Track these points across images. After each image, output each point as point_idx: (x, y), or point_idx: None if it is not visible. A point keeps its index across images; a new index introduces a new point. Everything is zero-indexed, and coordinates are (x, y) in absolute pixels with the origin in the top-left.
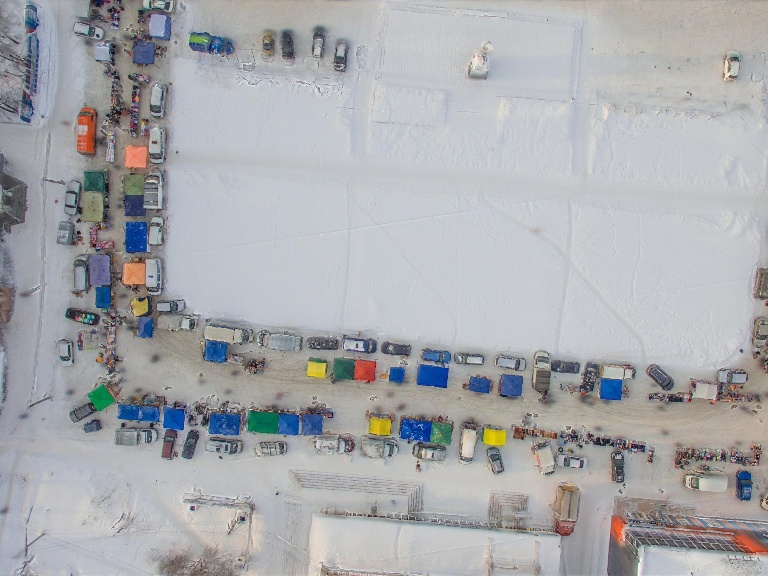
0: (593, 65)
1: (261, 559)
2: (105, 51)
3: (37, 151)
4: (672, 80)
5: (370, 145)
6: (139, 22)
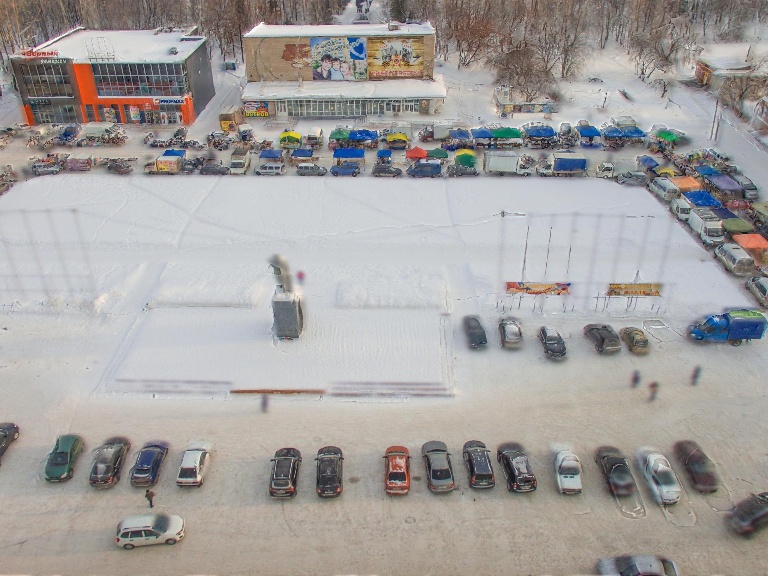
0: (95, 353)
1: (483, 101)
2: None
3: None
4: None
5: (444, 272)
6: None
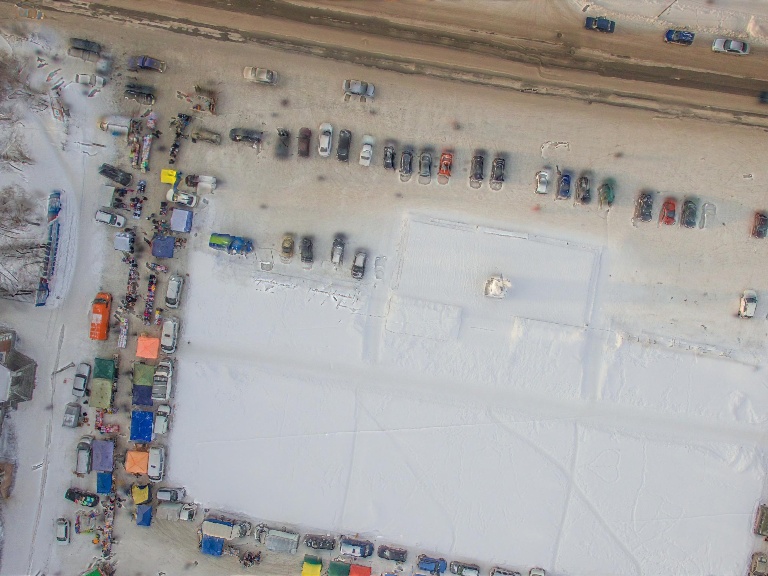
0: (610, 291)
1: None
2: (125, 242)
3: (50, 330)
4: (687, 312)
5: (382, 352)
6: (161, 213)
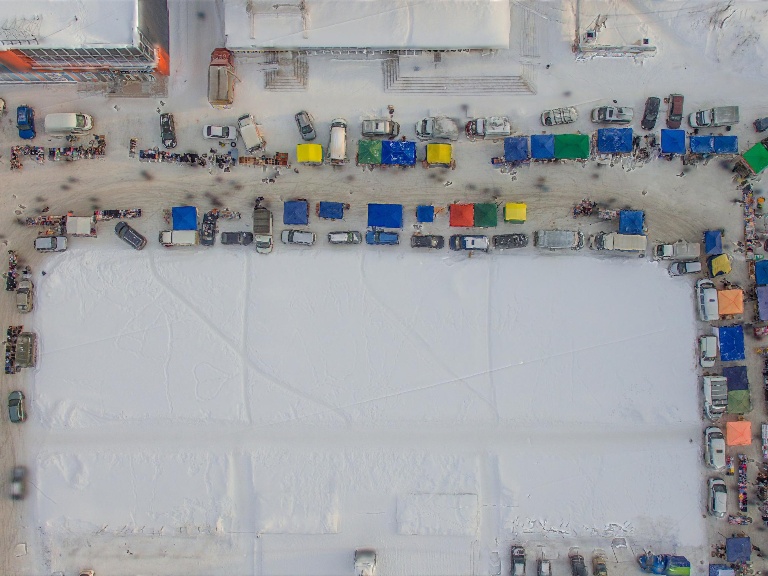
0: (239, 575)
1: None
2: None
3: None
4: (151, 566)
5: (478, 467)
6: None
